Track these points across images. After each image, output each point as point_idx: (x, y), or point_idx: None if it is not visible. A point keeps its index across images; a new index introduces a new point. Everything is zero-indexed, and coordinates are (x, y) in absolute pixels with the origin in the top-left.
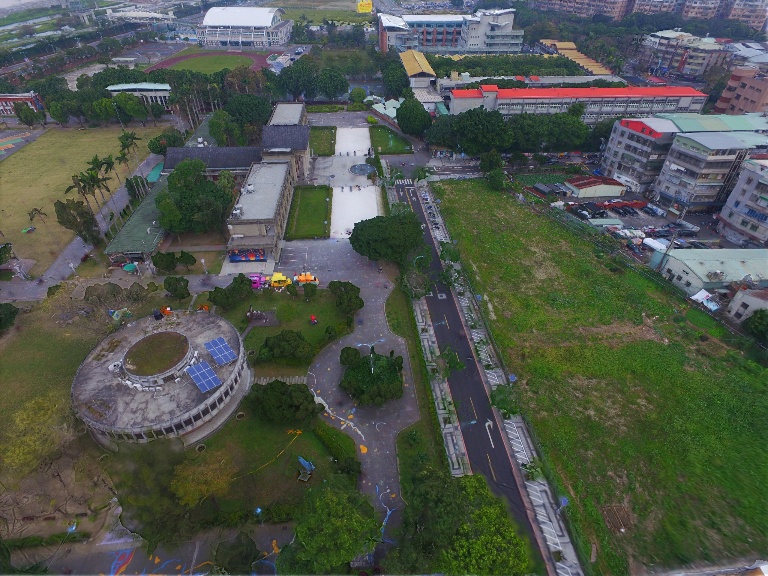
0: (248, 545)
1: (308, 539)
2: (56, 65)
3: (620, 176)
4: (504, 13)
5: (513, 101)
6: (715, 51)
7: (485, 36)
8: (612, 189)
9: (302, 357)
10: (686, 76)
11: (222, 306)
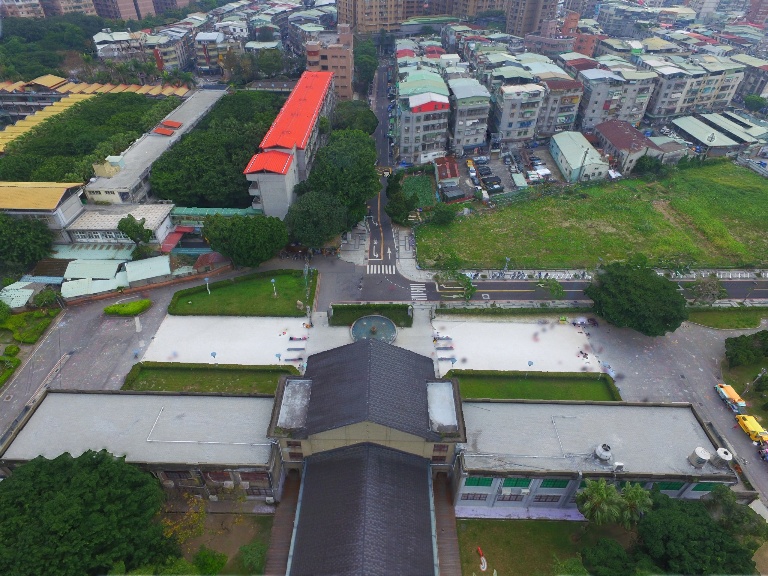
0: None
1: None
2: None
3: (427, 155)
4: None
5: None
6: (174, 42)
7: None
8: None
9: None
10: None
11: None
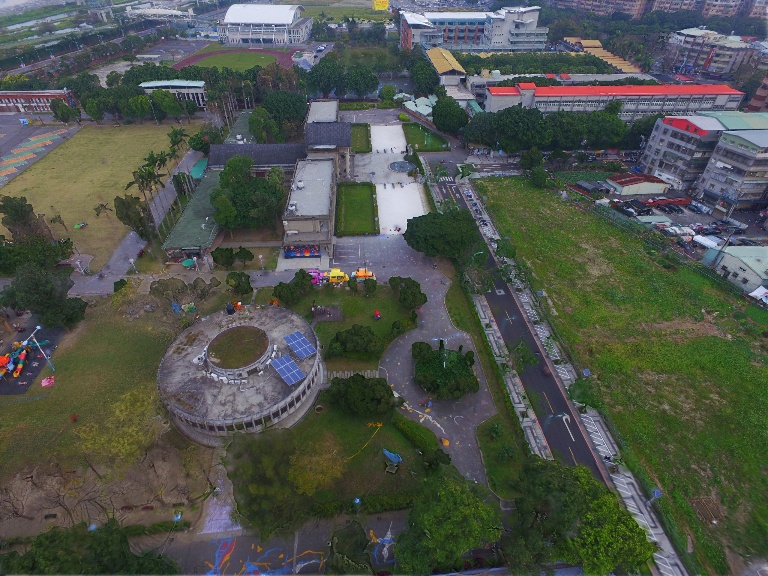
0: (361, 534)
1: (435, 527)
2: (82, 62)
3: (661, 174)
4: (529, 11)
5: (550, 99)
6: (742, 49)
7: (509, 34)
8: (655, 187)
9: (374, 351)
10: (712, 74)
11: (287, 301)
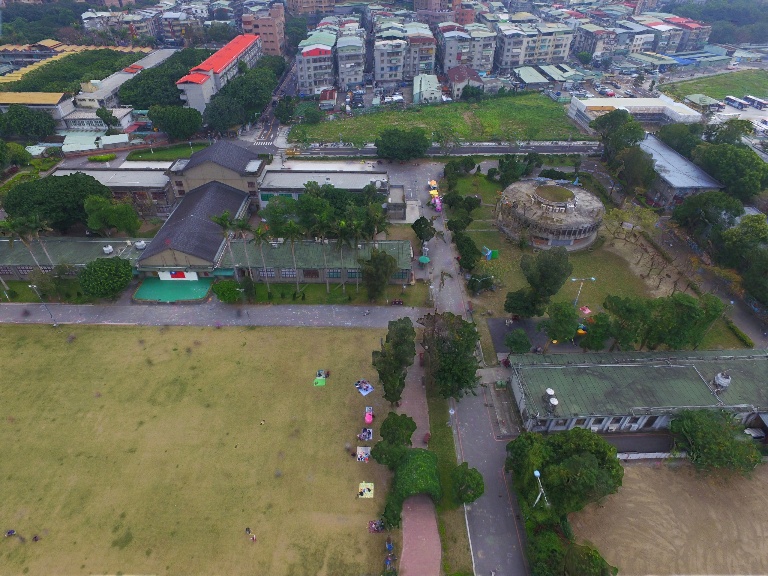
0: None
1: None
2: None
3: (319, 89)
4: None
5: None
6: (146, 20)
7: None
8: None
9: None
10: None
11: None
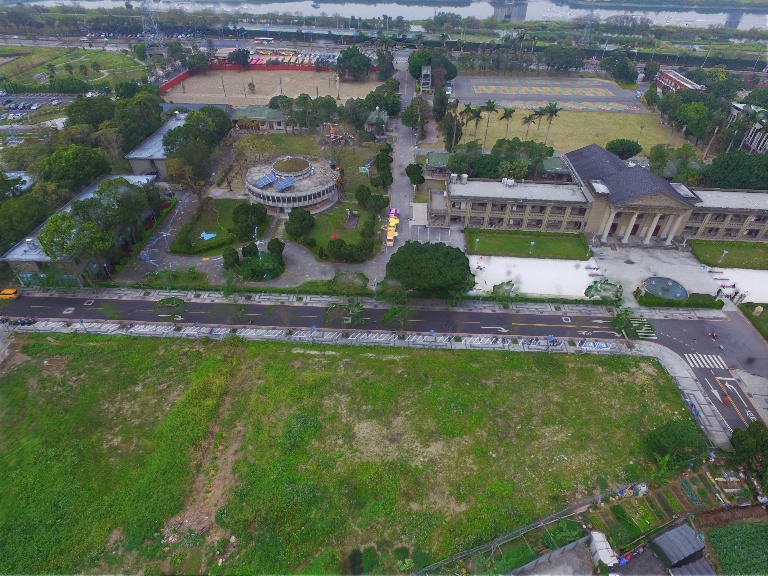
0: (152, 196)
1: None
2: None
3: None
4: None
5: None
6: None
7: None
8: None
9: None
10: None
11: None
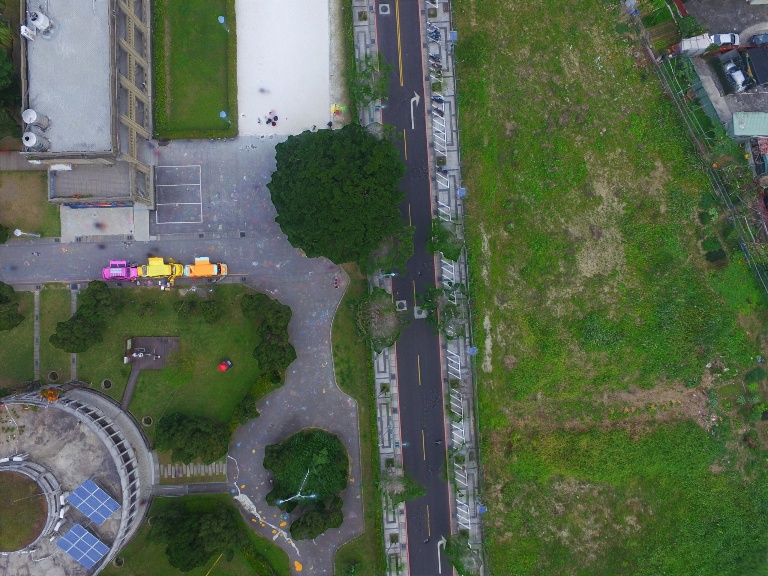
0: None
1: None
2: None
3: None
4: None
5: None
6: None
7: None
8: None
9: None
10: None
11: None
